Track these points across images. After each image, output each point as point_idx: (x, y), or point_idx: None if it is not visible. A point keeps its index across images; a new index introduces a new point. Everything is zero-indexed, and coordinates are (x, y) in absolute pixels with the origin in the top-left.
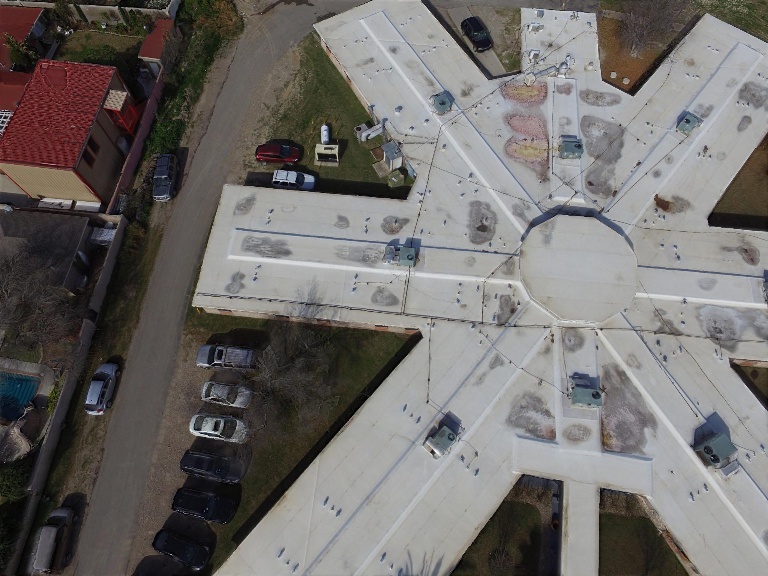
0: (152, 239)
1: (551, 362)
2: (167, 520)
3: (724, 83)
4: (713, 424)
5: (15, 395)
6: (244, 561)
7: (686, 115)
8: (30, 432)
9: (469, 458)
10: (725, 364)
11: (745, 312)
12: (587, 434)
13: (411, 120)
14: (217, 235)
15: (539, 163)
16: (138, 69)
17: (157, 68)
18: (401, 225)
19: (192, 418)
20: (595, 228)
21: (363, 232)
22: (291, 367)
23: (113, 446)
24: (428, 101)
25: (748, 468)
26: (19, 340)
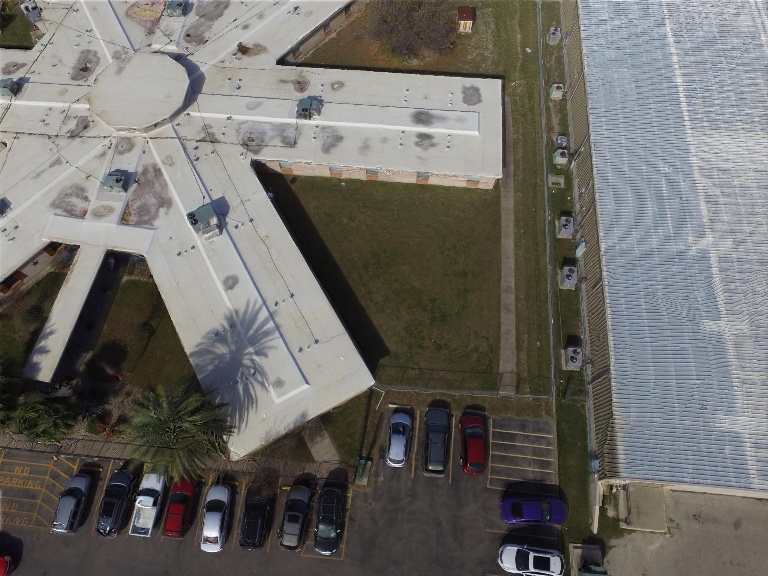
0: None
1: (102, 163)
2: None
3: None
4: (218, 204)
5: None
6: None
7: None
8: None
9: (10, 230)
10: (246, 163)
11: (278, 126)
12: (110, 211)
13: None
14: None
15: (151, 21)
16: None
17: None
18: (19, 68)
19: None
20: (163, 61)
21: None
22: None
23: None
24: None
25: (234, 234)
26: None
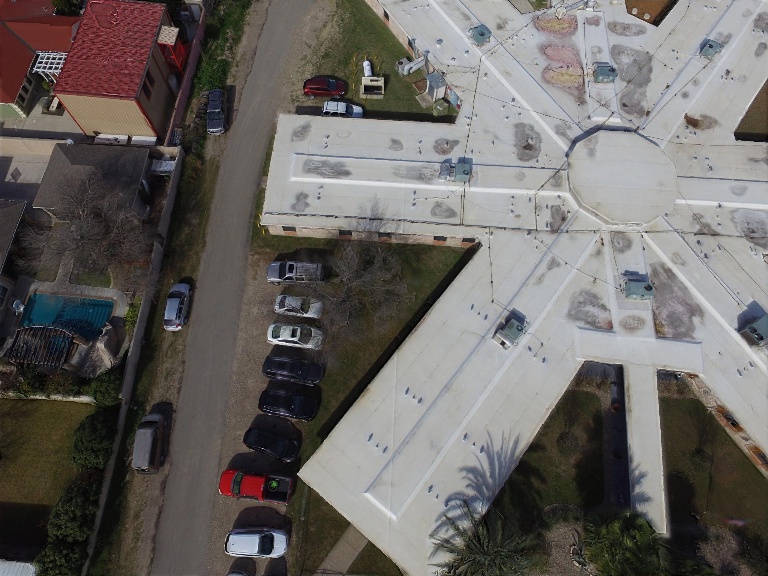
0: (209, 170)
1: (603, 262)
2: (253, 421)
3: (740, 13)
4: (753, 310)
5: (88, 320)
6: (336, 447)
7: (709, 41)
8: (111, 349)
9: (535, 348)
10: (760, 259)
11: None
12: (641, 323)
13: (452, 52)
14: (278, 160)
15: (576, 88)
16: (177, 13)
17: (198, 10)
18: (452, 146)
19: (269, 328)
20: (635, 141)
21: (417, 153)
22: (369, 268)
23: (193, 358)
24: (467, 34)
25: None
26: (88, 267)
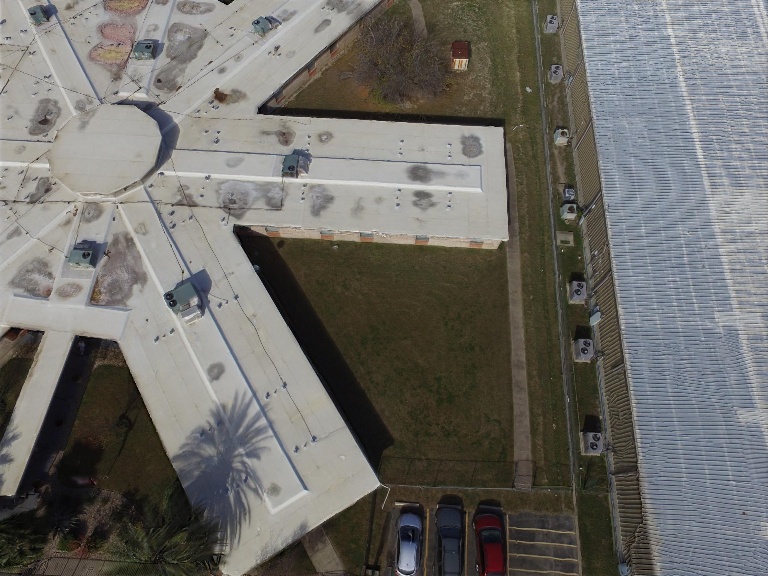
0: None
1: (67, 233)
2: None
3: None
4: (198, 279)
5: None
6: None
7: (259, 17)
8: None
9: None
10: (228, 229)
11: (263, 185)
12: (77, 291)
13: (10, 31)
14: None
15: (117, 65)
16: None
17: None
18: None
19: None
20: (132, 114)
21: None
22: None
23: None
24: None
25: (217, 314)
26: None
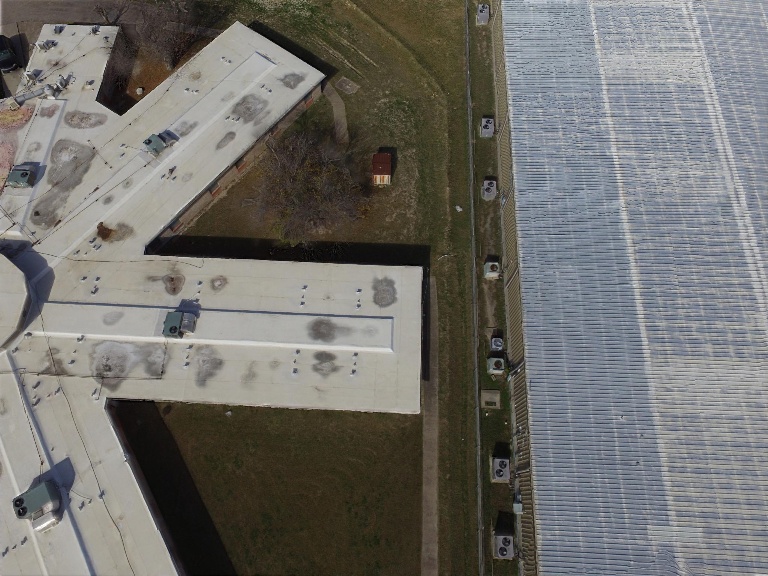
0: None
1: None
2: None
3: (220, 97)
4: (60, 471)
5: None
6: None
7: (151, 135)
8: None
9: None
10: (99, 405)
11: (142, 347)
12: None
13: None
14: None
15: None
16: None
17: None
18: None
19: None
20: None
21: None
22: None
23: None
24: None
25: (78, 517)
26: None
